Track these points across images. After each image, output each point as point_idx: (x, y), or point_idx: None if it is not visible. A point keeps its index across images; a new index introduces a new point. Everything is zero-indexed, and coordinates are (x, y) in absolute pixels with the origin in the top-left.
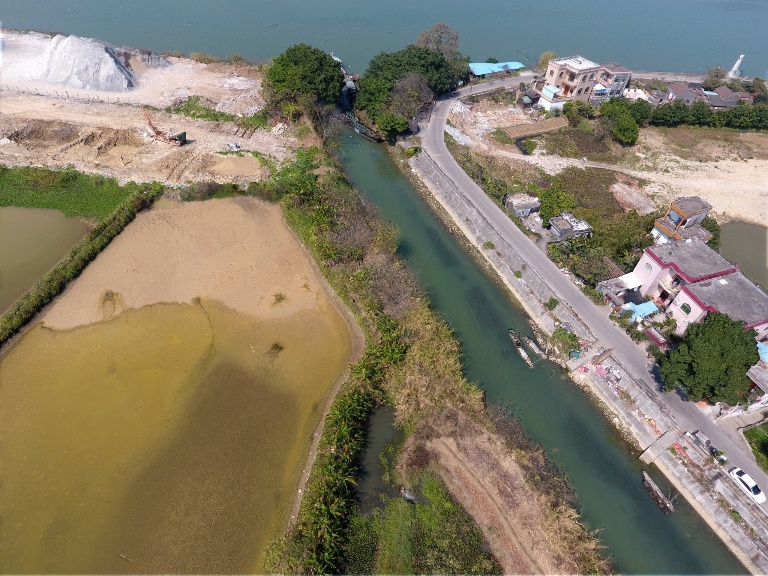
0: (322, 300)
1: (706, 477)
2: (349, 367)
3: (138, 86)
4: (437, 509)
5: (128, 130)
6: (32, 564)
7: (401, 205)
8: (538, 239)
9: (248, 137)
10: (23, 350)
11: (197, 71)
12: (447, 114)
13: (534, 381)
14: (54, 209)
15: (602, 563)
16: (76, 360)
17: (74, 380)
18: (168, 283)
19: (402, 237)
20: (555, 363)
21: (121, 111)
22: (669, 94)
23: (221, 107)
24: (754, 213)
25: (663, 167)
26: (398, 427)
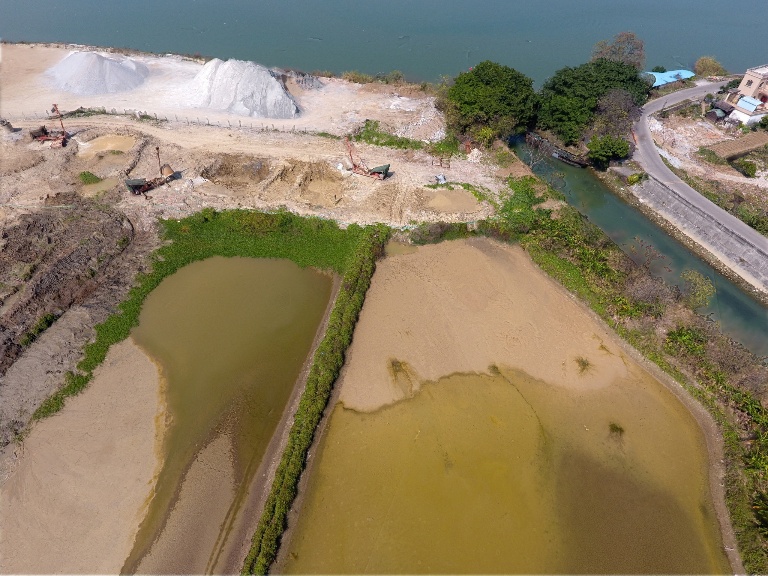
0: (631, 365)
1: None
2: (743, 462)
3: (304, 111)
4: None
5: (321, 163)
6: None
7: (649, 242)
8: None
9: (448, 166)
10: (338, 439)
11: (354, 92)
12: (649, 133)
13: None
14: (283, 258)
15: None
16: (402, 451)
17: (413, 478)
18: (452, 348)
19: (675, 283)
20: None
21: (300, 140)
22: None
23: (404, 133)
24: None
25: None
26: None
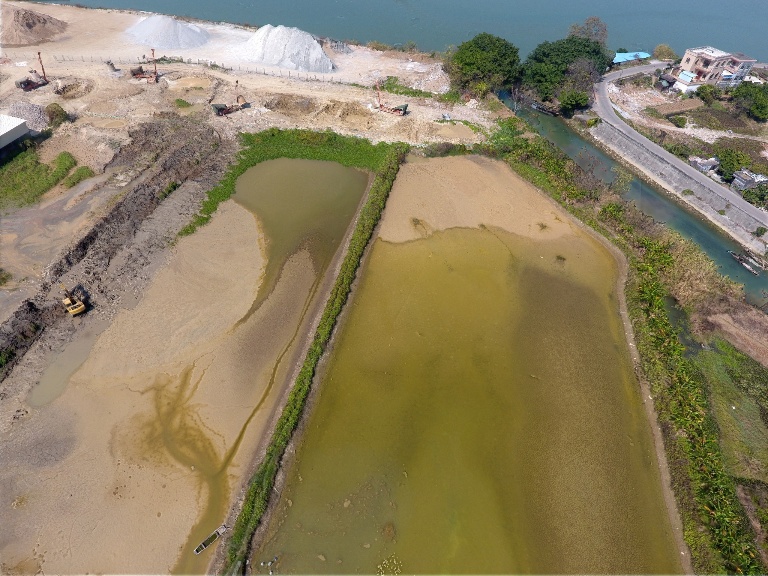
0: (575, 228)
1: None
2: (636, 267)
3: (338, 68)
4: (733, 357)
5: (355, 103)
6: (476, 378)
7: None
8: None
9: (451, 110)
10: (379, 255)
11: (376, 57)
12: (607, 93)
13: (763, 284)
14: (332, 161)
15: None
16: (421, 262)
17: (429, 274)
18: (454, 214)
19: None
20: None
21: (337, 88)
22: None
23: (417, 86)
24: None
25: None
26: (679, 309)
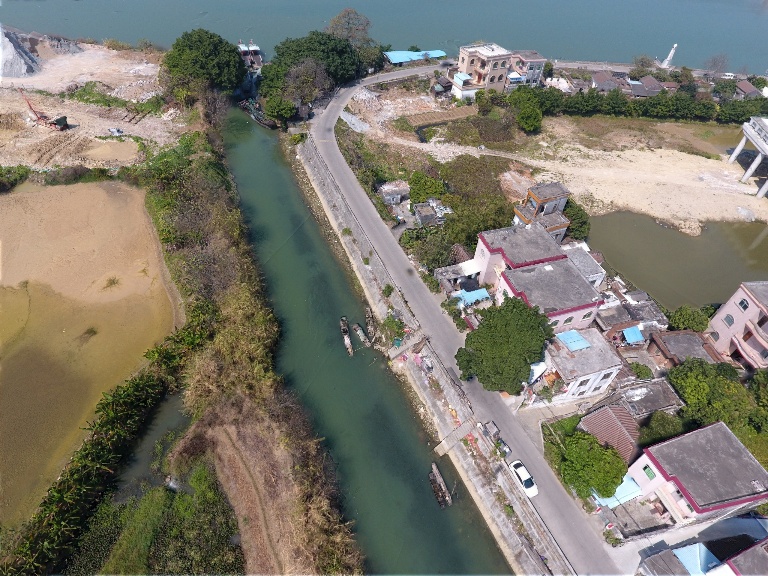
0: (156, 285)
1: (490, 469)
2: (144, 352)
3: (39, 72)
4: (198, 499)
5: (11, 114)
6: None
7: (274, 191)
8: (397, 226)
9: (135, 122)
10: None
11: (107, 57)
12: (347, 101)
13: (350, 369)
14: None
15: (348, 557)
16: None
17: None
18: (0, 266)
19: (263, 223)
20: (379, 351)
21: (13, 96)
22: (592, 83)
23: (116, 93)
24: (643, 202)
25: (562, 156)
26: (187, 414)
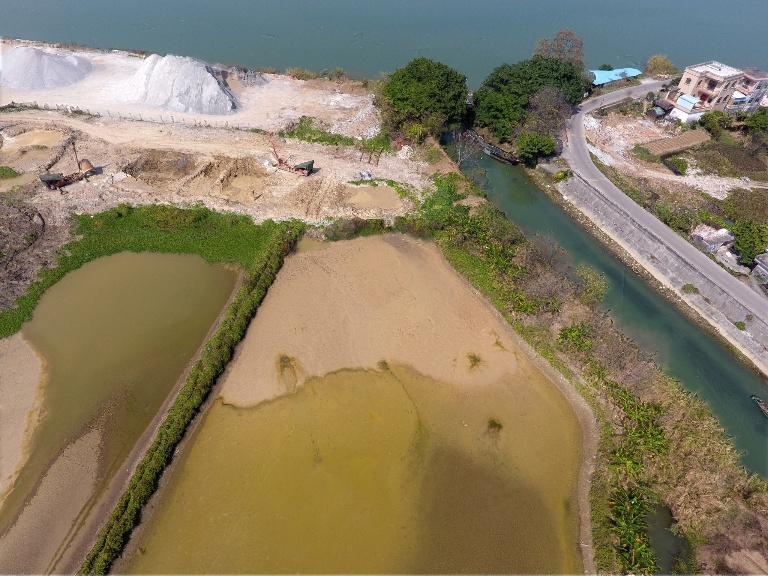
0: (523, 361)
1: None
2: (607, 458)
3: (241, 107)
4: None
5: (247, 159)
6: None
7: (566, 239)
8: None
9: (376, 163)
10: (210, 435)
11: (296, 88)
12: (583, 131)
13: None
14: (192, 254)
15: None
16: (273, 447)
17: (279, 474)
18: (345, 343)
19: None
20: None
21: (232, 136)
22: None
23: (337, 129)
24: None
25: None
26: (678, 534)
